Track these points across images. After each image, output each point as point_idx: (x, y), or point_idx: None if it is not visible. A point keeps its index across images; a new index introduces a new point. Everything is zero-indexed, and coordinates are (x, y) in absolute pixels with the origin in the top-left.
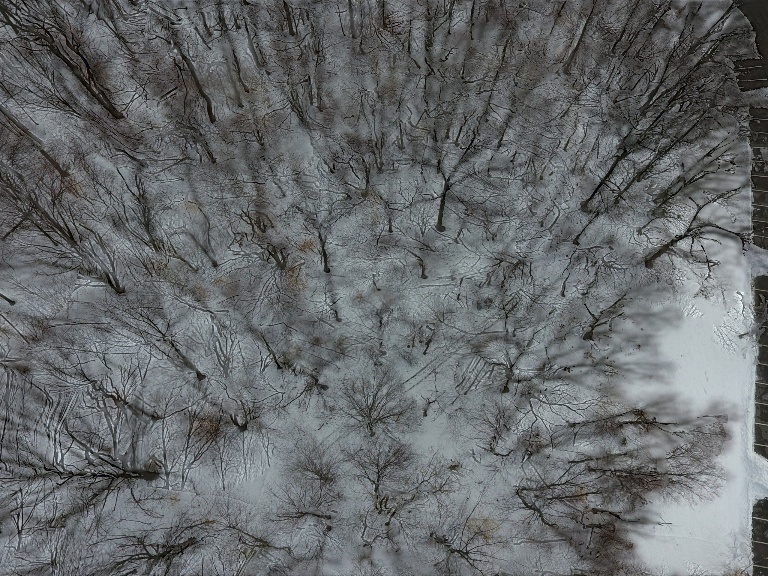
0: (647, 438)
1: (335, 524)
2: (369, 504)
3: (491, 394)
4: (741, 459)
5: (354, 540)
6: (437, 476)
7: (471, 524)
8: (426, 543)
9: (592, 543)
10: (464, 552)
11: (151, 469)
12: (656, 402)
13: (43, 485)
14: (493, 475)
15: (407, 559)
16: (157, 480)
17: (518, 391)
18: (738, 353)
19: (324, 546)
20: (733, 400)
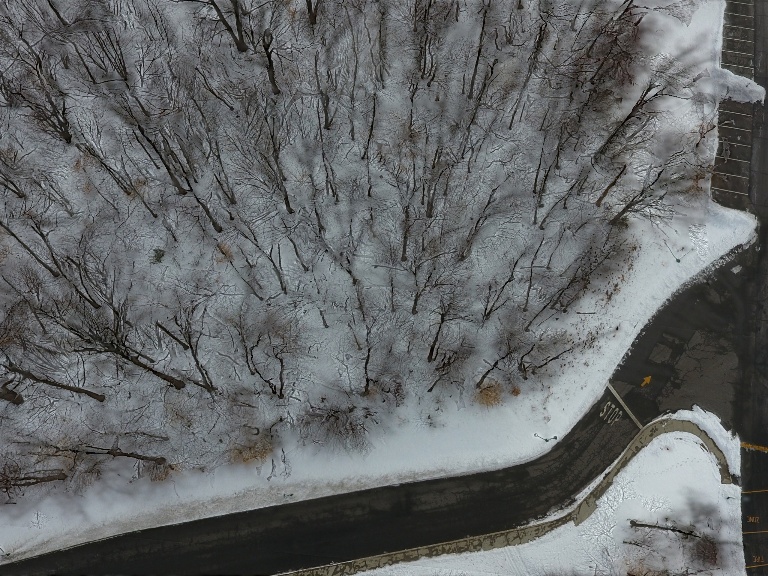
0: (634, 44)
1: (387, 84)
2: (414, 68)
3: (509, 5)
4: (710, 71)
5: (403, 94)
6: (467, 57)
7: (495, 84)
8: (459, 96)
9: (590, 102)
10: (489, 105)
11: (243, 36)
12: (642, 23)
13: (159, 46)
14: (511, 58)
15: (445, 104)
16: (247, 51)
17: (531, 6)
18: (709, 4)
19: (379, 97)
20: (704, 33)
